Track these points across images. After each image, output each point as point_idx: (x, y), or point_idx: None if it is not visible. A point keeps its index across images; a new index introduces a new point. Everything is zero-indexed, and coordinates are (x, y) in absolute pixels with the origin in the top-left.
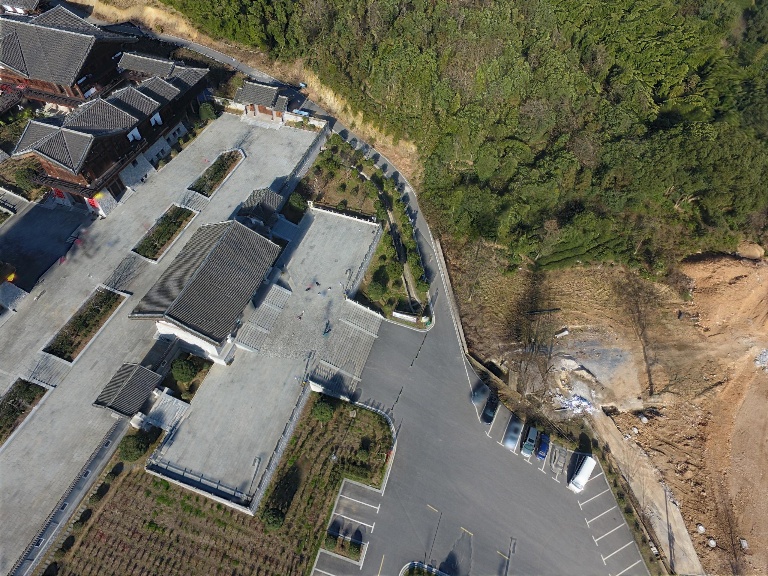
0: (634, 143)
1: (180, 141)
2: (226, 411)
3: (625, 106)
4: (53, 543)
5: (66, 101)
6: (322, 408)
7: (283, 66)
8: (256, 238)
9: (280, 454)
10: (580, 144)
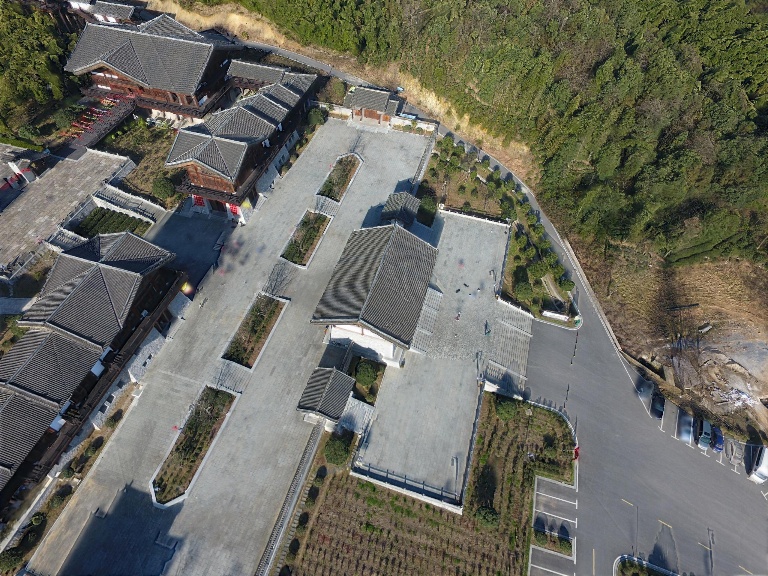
0: (750, 140)
1: (297, 147)
2: (411, 413)
3: (726, 104)
4: (280, 547)
5: (181, 109)
6: (509, 407)
7: (375, 70)
8: (416, 241)
9: (472, 453)
10: (700, 142)
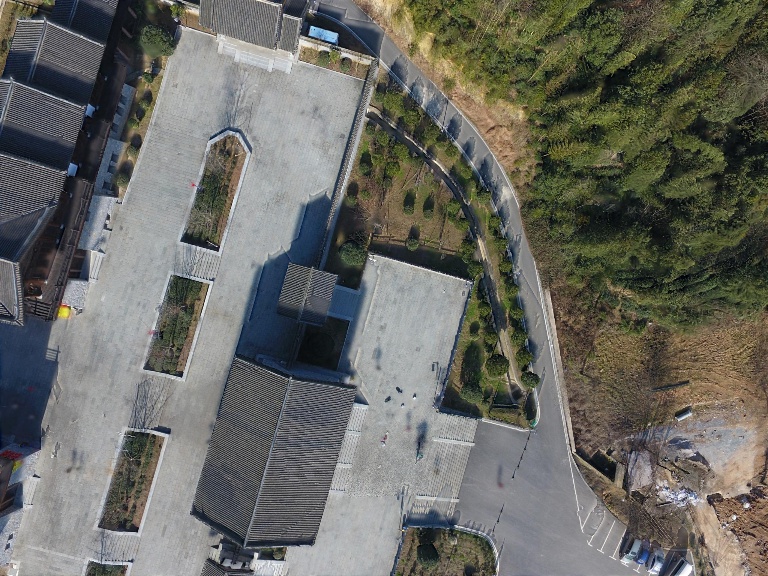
0: None
1: (133, 127)
2: (325, 565)
3: None
4: None
5: None
6: (429, 566)
7: None
8: (323, 390)
9: None
10: None
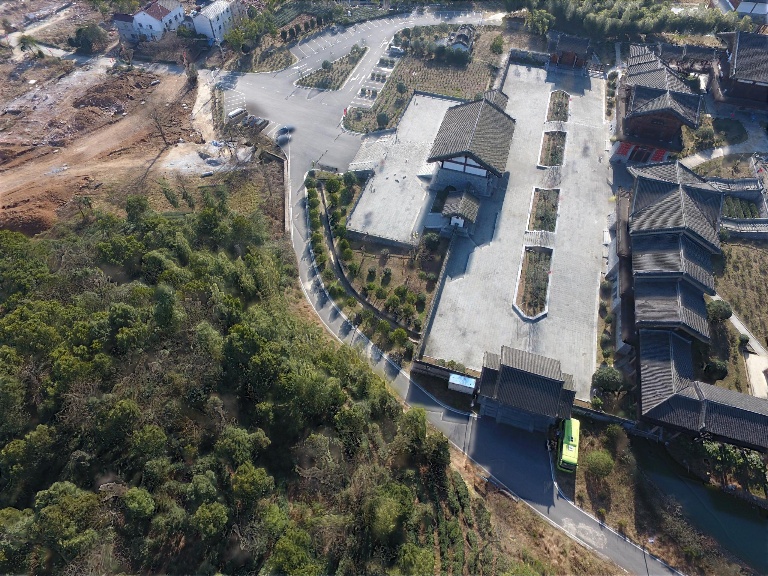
0: None
1: None
2: (440, 120)
3: None
4: None
5: None
6: None
7: (547, 568)
8: None
9: None
10: None
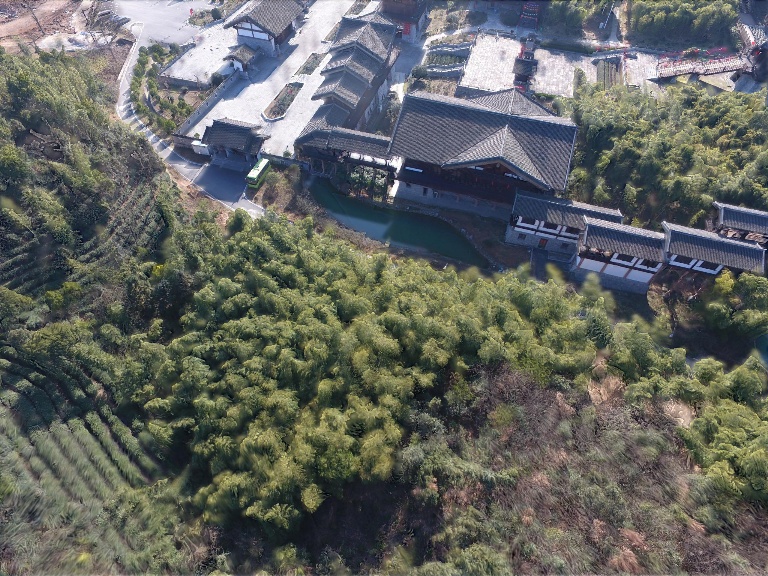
0: None
1: None
2: None
3: None
4: None
5: None
6: None
7: None
8: None
9: None
10: None
